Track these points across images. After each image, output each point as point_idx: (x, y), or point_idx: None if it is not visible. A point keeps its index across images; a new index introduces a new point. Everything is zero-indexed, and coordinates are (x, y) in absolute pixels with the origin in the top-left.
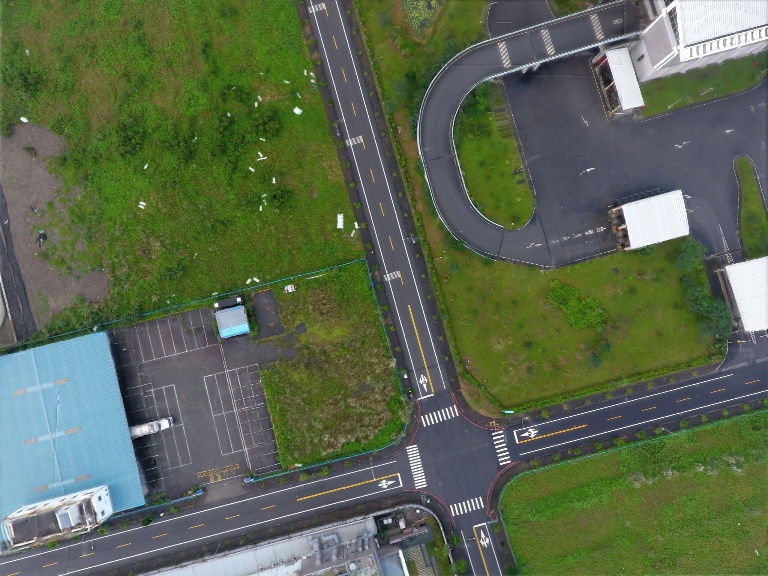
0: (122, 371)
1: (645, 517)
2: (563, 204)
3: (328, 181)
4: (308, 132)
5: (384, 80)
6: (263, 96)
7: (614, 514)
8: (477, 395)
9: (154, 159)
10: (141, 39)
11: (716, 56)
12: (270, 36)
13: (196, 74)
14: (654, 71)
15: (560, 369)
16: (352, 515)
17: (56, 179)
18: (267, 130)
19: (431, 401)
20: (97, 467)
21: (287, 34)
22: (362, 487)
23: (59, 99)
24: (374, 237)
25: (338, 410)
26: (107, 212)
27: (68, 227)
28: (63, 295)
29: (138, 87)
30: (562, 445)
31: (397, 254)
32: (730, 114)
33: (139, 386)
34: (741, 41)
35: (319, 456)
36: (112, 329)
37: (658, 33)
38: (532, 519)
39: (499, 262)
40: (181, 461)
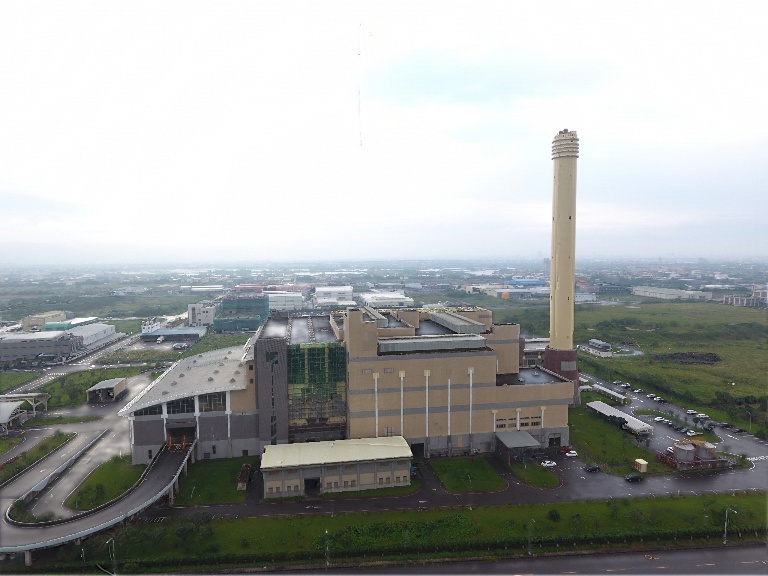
0: None
1: None
2: None
3: None
4: None
5: None
6: None
7: None
8: None
9: None
10: None
11: None
12: None
13: None
14: None
15: None
16: (82, 357)
17: None
18: None
19: None
20: None
21: None
22: None
23: None
24: None
25: None
26: None
27: None
28: None
29: None
30: None
31: None
32: None
33: None
34: None
35: None
36: None
37: None
38: None
39: None
40: None
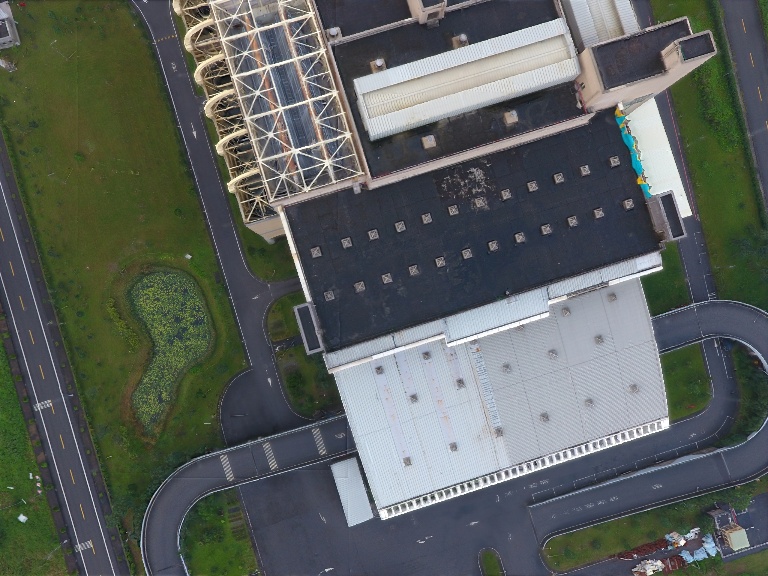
0: None
1: None
2: None
3: None
4: (33, 542)
5: (113, 481)
6: None
7: None
8: None
9: None
10: None
11: None
12: None
13: None
14: None
15: None
16: None
17: None
18: None
19: None
20: None
21: (9, 438)
22: None
23: None
24: None
25: None
26: None
27: None
28: None
29: None
30: None
31: None
32: (474, 505)
33: None
34: (443, 495)
35: None
36: None
37: None
38: None
39: None
40: None
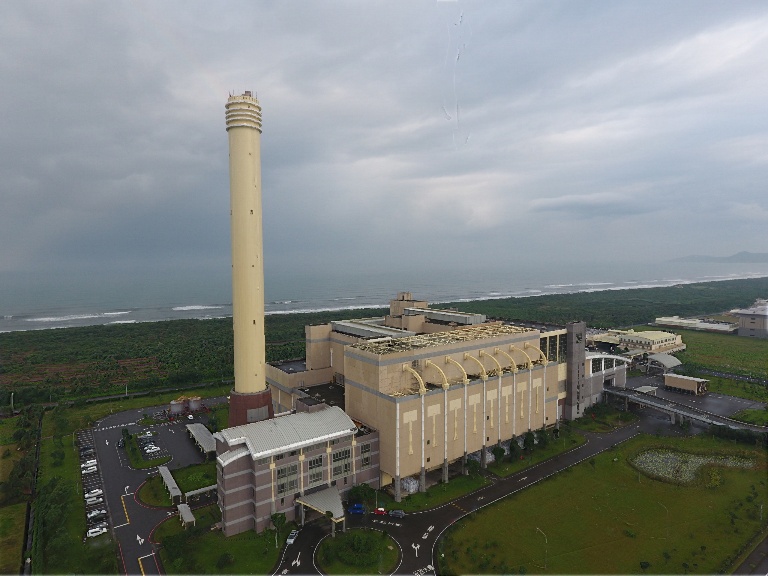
0: None
1: None
2: None
3: None
4: None
5: None
6: None
7: None
8: None
9: None
10: None
11: None
12: None
13: None
14: None
15: None
16: None
17: None
18: None
19: None
20: None
21: None
22: None
23: None
24: None
25: None
26: None
27: None
28: None
29: None
30: None
31: None
32: None
33: None
34: None
35: None
36: None
37: None
38: None
39: None
40: None
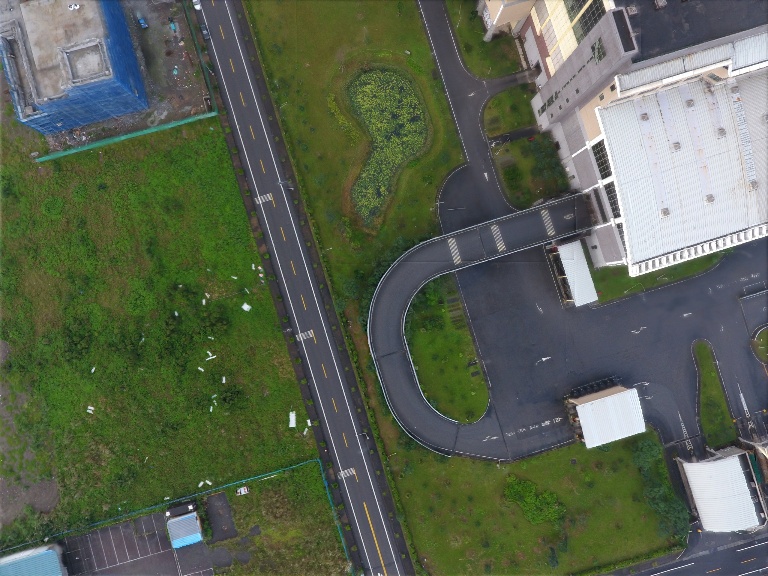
0: None
1: None
2: (519, 395)
3: (279, 379)
4: (257, 329)
5: (334, 272)
6: (211, 293)
7: None
8: None
9: (101, 362)
10: (84, 239)
11: None
12: (216, 231)
13: (142, 273)
14: (607, 265)
15: (518, 565)
16: None
17: (2, 387)
18: (215, 331)
19: None
20: None
21: (233, 228)
22: None
23: (3, 304)
24: (327, 434)
25: None
26: (55, 419)
27: (16, 436)
28: (13, 506)
29: (83, 288)
30: None
31: (351, 451)
32: (687, 297)
33: None
34: (691, 254)
35: None
36: (64, 538)
37: (608, 236)
38: None
39: (454, 457)
40: None
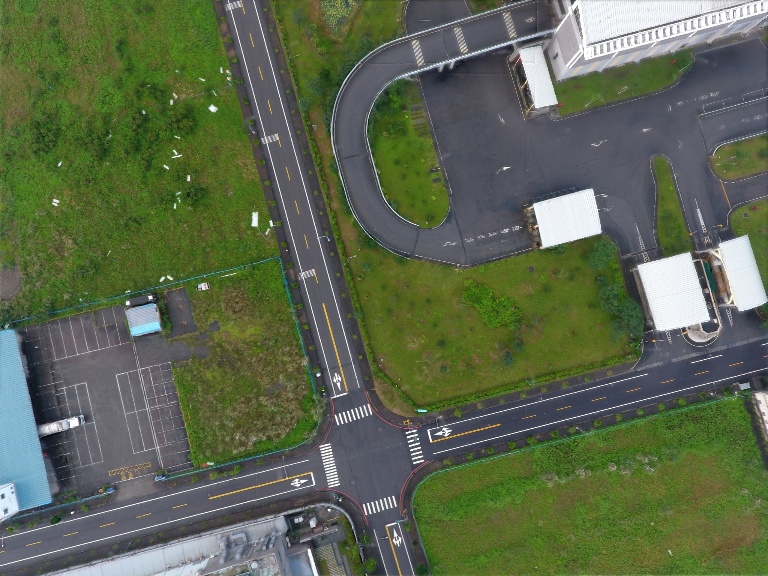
0: (34, 369)
1: (558, 516)
2: (479, 203)
3: (243, 179)
4: (223, 130)
5: (300, 78)
6: (178, 94)
7: (527, 513)
8: (391, 394)
9: (68, 156)
10: (56, 36)
11: (631, 55)
12: (186, 33)
13: (111, 71)
14: (567, 69)
15: (474, 368)
16: (264, 514)
17: None
18: (181, 128)
19: (345, 400)
20: (3, 465)
21: (203, 32)
22: (275, 486)
23: None
24: (289, 235)
25: (250, 408)
26: (20, 209)
27: None
28: None
29: (52, 84)
30: (476, 444)
31: (312, 252)
32: (647, 113)
33: (51, 384)
34: (645, 39)
35: (231, 455)
36: (24, 327)
37: (567, 31)
38: (445, 518)
39: (414, 261)
40: (92, 459)
